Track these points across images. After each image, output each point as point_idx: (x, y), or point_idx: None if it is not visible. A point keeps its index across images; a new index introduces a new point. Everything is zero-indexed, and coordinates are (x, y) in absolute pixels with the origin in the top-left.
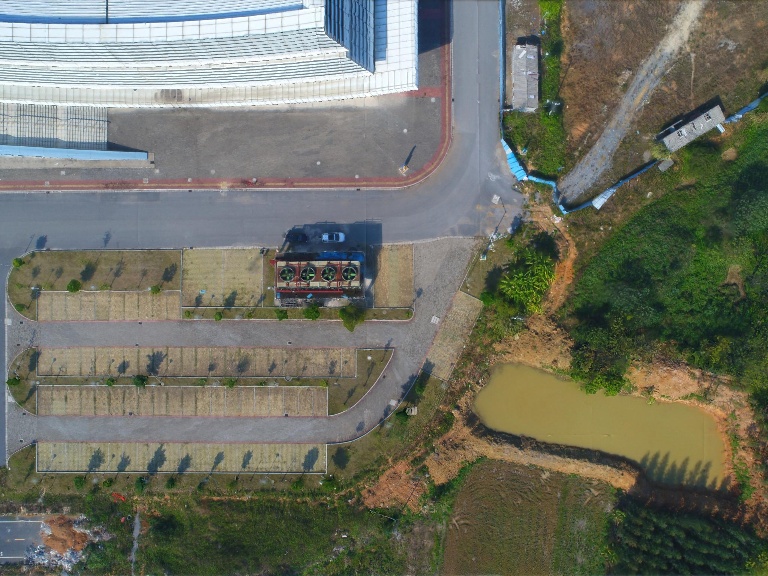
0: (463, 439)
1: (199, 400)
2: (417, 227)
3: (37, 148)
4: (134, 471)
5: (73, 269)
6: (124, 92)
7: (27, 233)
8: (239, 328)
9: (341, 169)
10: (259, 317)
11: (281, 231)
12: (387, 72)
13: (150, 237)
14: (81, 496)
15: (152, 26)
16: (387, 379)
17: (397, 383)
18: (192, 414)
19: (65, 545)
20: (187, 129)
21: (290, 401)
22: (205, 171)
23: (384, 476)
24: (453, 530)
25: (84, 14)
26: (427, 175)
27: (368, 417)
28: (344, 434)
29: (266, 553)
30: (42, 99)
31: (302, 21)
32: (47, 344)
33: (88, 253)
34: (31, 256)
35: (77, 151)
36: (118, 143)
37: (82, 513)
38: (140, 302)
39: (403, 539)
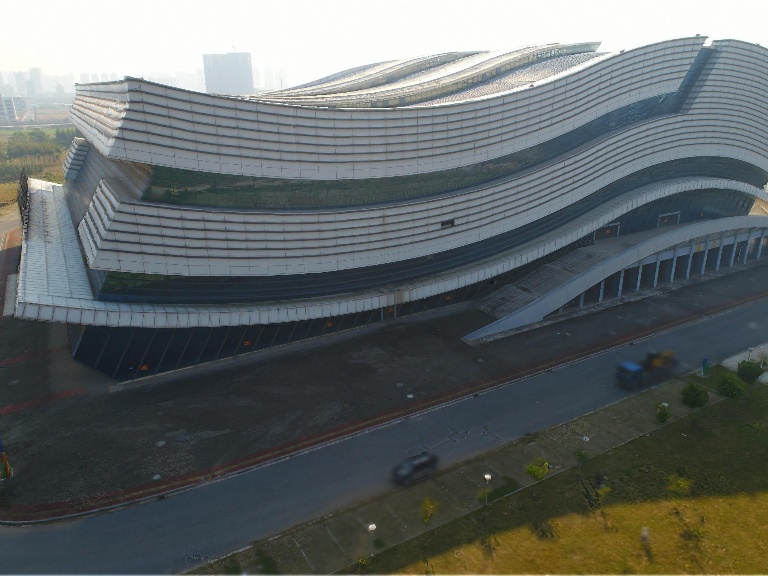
0: None
1: None
2: None
3: None
4: None
5: None
6: None
7: None
8: None
9: None
10: None
11: None
12: None
13: None
14: None
15: None
16: None
17: None
18: None
19: None
20: None
21: None
22: None
23: None
24: None
25: None
26: None
27: None
28: None
29: None
30: None
31: None
32: None
33: None
34: None
35: None
36: None
37: None
38: None
39: None
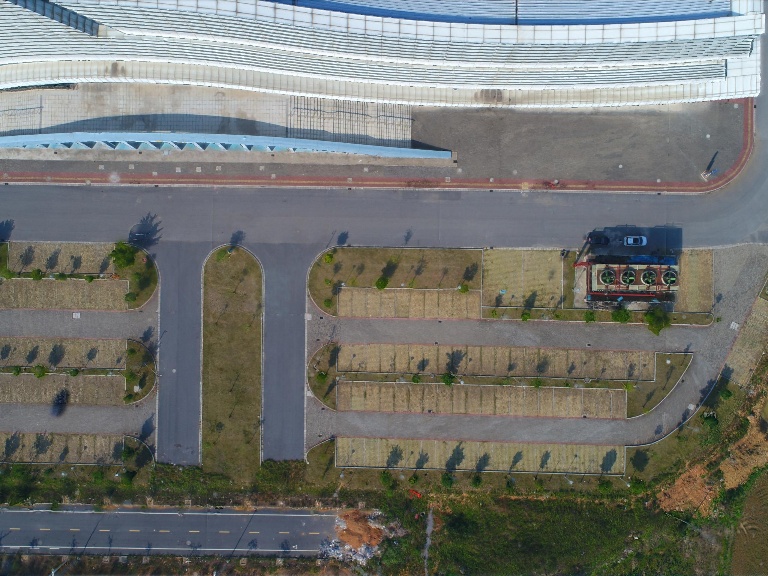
0: (757, 445)
1: (498, 399)
2: (717, 233)
3: (354, 145)
4: (432, 468)
5: (374, 266)
6: (445, 91)
7: (329, 229)
8: (539, 329)
9: (643, 173)
10: (559, 318)
11: (582, 233)
12: (726, 78)
13: (451, 236)
14: (377, 492)
15: (570, 28)
16: (686, 383)
17: (696, 387)
18: (491, 413)
19: (361, 540)
20: (491, 129)
21: (589, 403)
22: (507, 171)
23: (680, 480)
24: (741, 535)
25: (494, 14)
26: (728, 181)
27: (666, 421)
28: (642, 437)
29: (564, 553)
30: (367, 96)
31: (738, 28)
32: (347, 340)
33: (389, 250)
34: (333, 252)
35: (389, 148)
36: (422, 141)
37: (377, 509)
38: (440, 300)
39: (691, 542)
